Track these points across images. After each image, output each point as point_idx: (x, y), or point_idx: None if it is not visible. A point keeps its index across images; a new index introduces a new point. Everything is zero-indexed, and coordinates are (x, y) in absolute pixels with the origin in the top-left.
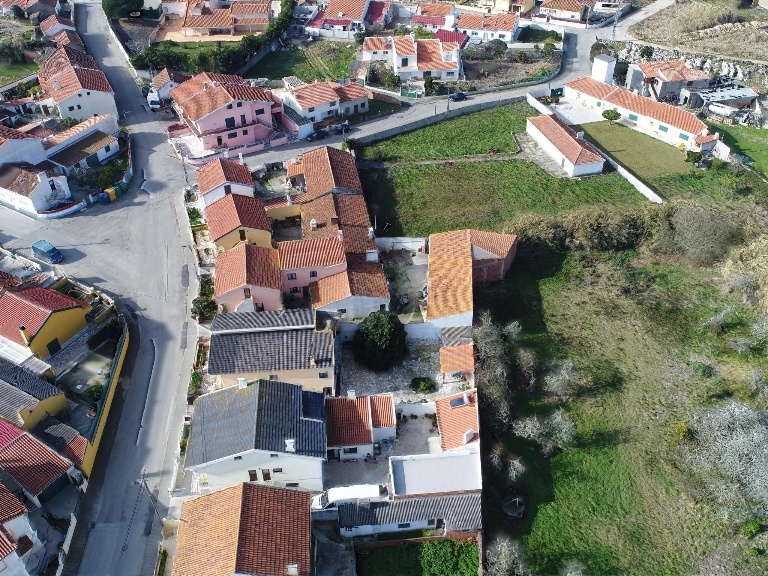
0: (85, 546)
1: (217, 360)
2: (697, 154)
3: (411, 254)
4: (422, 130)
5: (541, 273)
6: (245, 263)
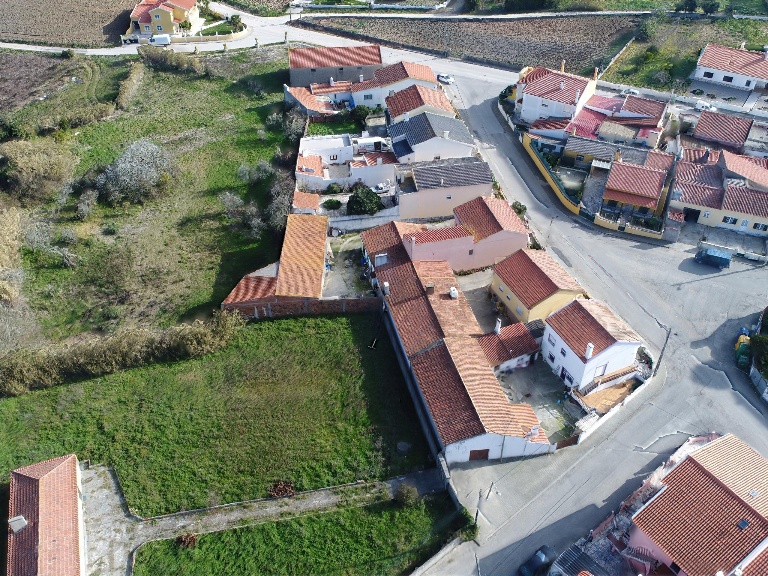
0: None
1: None
2: None
3: None
4: None
5: (204, 310)
6: None
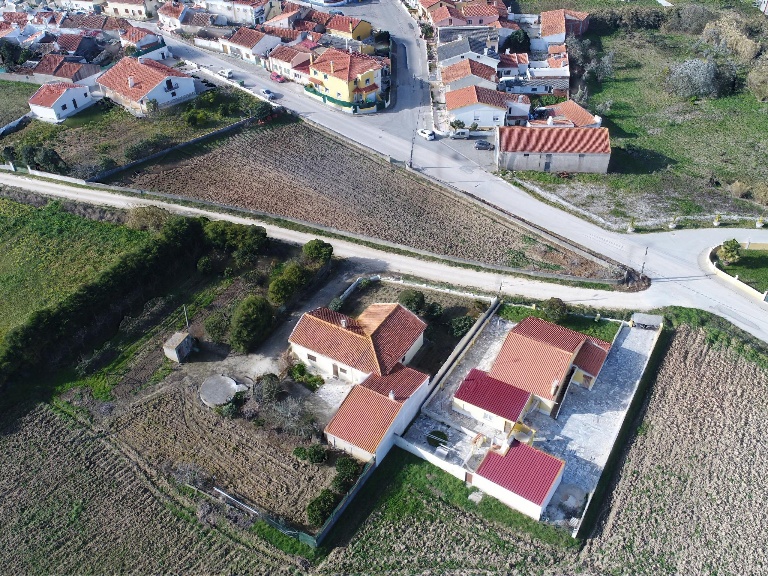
0: (397, 90)
1: (443, 38)
2: None
3: (530, 24)
4: None
5: (602, 34)
6: (448, 11)
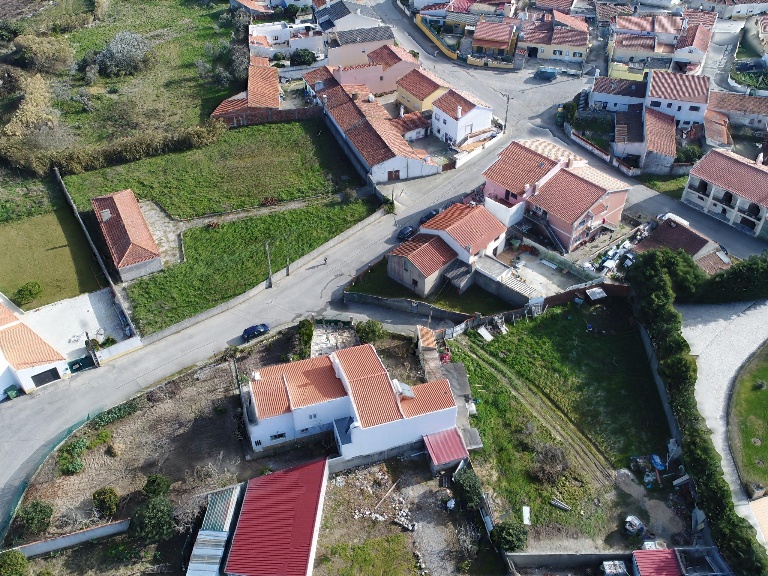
0: None
1: None
2: None
3: None
4: (306, 252)
5: None
6: None
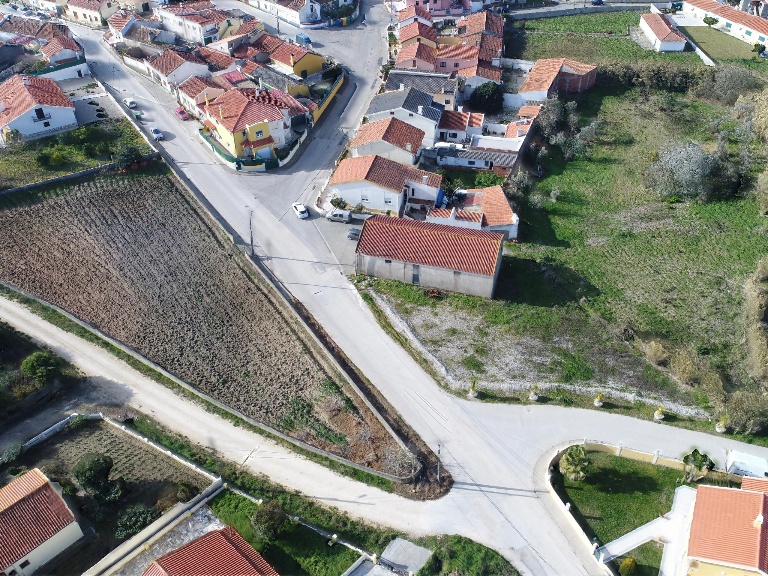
0: (310, 143)
1: (391, 84)
2: (762, 46)
3: (524, 72)
4: (561, 17)
5: (608, 94)
6: (417, 49)
